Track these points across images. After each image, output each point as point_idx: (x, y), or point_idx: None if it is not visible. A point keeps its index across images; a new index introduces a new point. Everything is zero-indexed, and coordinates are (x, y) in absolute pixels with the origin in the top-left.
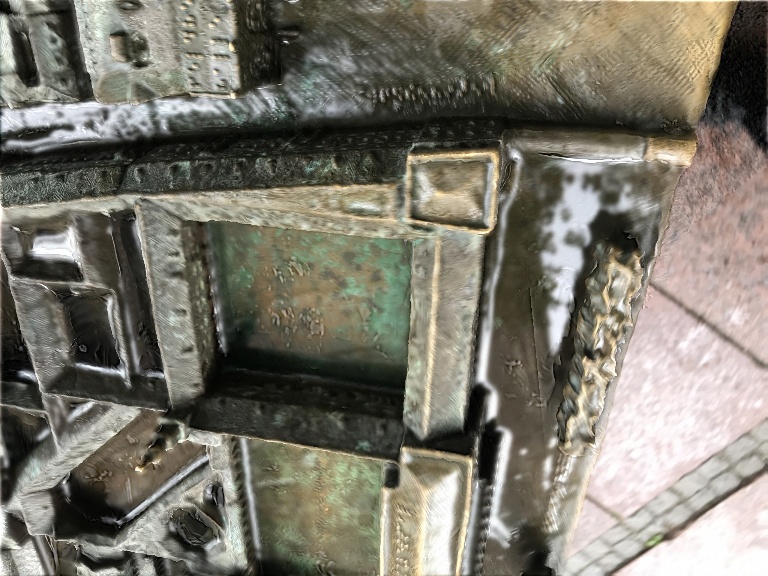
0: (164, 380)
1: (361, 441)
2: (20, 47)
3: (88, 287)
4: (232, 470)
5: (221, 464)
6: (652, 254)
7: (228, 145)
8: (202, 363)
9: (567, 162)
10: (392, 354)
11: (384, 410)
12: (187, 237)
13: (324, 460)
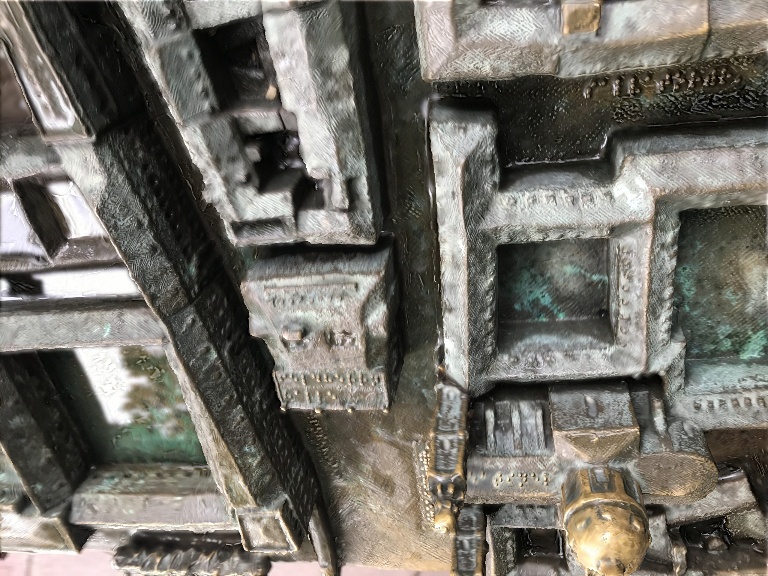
0: None
1: (39, 483)
2: None
3: None
4: None
5: None
6: None
7: None
8: None
9: None
10: (119, 446)
11: (72, 472)
12: None
13: None
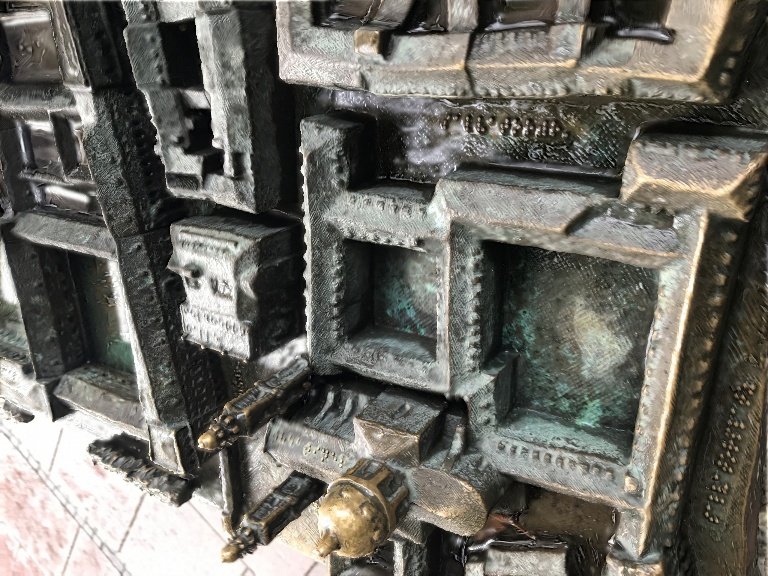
0: (35, 202)
1: (41, 354)
2: None
3: None
4: None
5: None
6: (195, 496)
7: (182, 289)
8: None
9: None
10: (110, 352)
11: (69, 357)
12: None
13: None
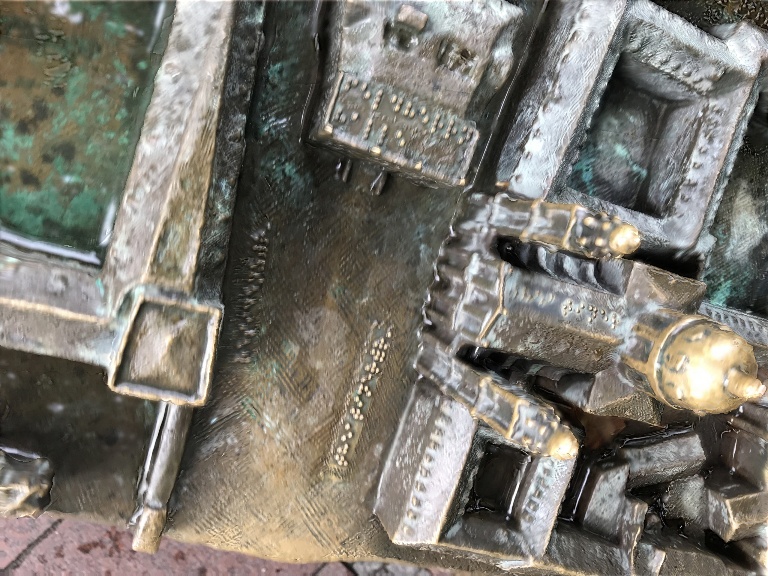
0: None
1: None
2: None
3: None
4: None
5: None
6: None
7: None
8: None
9: (148, 423)
10: None
11: None
12: None
13: None
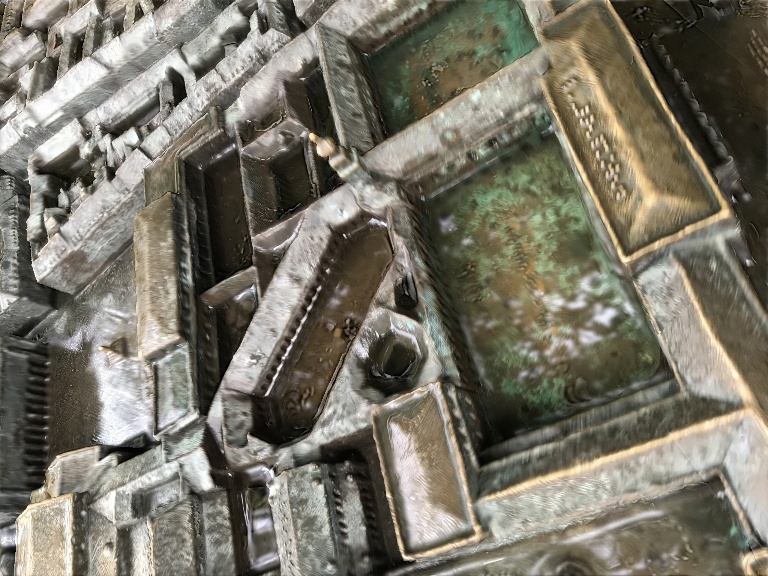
0: None
1: None
2: (262, 25)
3: (290, 130)
4: (417, 247)
5: (403, 231)
6: None
7: None
8: (372, 132)
9: None
10: None
11: None
12: (352, 55)
13: (515, 226)
